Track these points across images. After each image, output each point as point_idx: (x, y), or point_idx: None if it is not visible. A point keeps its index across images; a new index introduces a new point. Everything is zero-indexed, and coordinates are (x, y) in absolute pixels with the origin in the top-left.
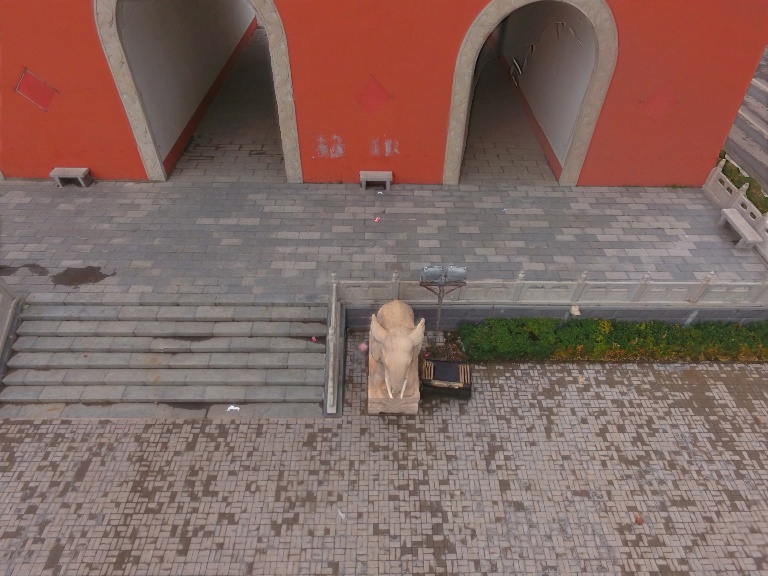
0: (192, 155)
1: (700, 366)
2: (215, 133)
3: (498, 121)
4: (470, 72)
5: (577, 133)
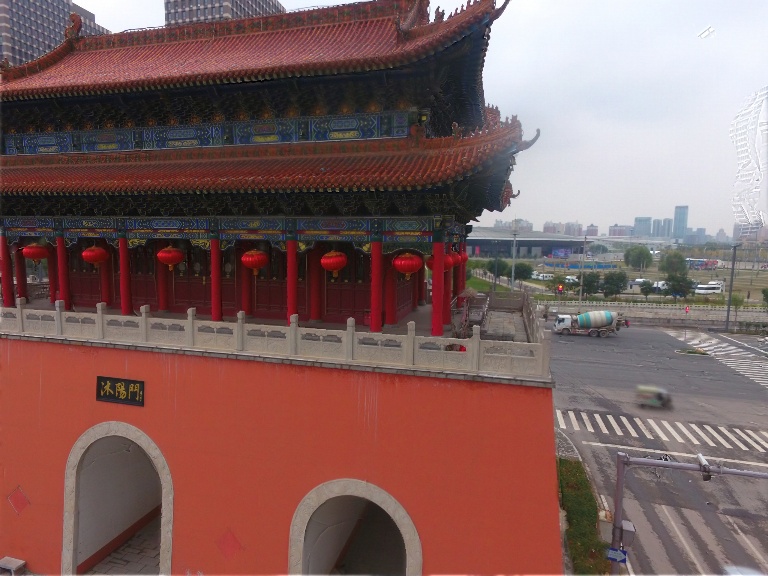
0: (116, 557)
1: None
2: (152, 534)
3: (397, 561)
4: (301, 539)
5: None
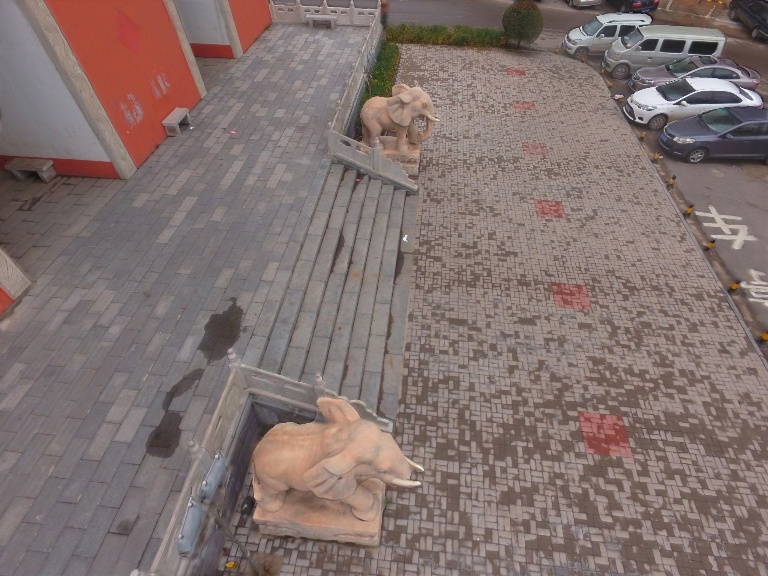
0: None
1: (399, 74)
2: None
3: None
4: None
5: (224, 8)
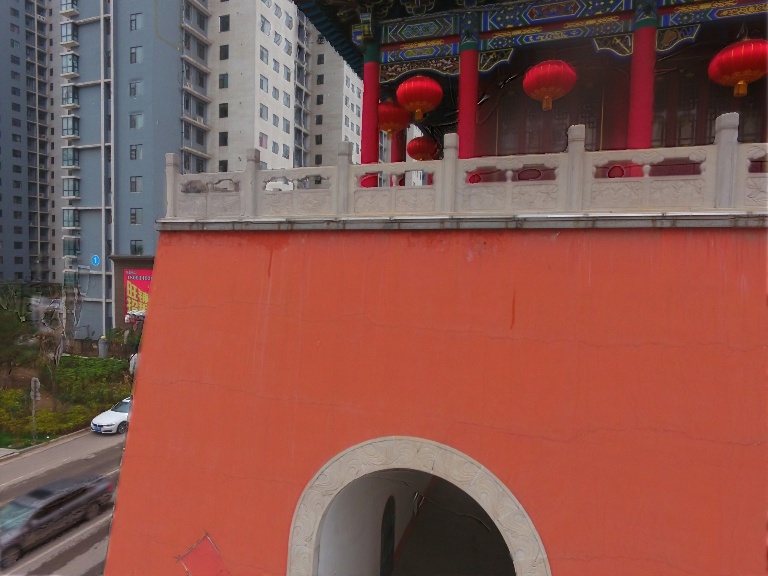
0: None
1: None
2: None
3: None
4: None
5: None
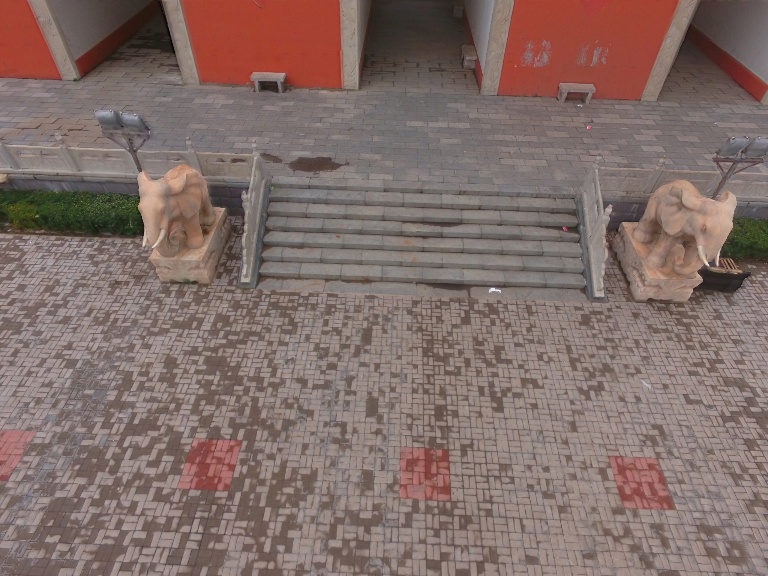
0: (373, 70)
1: None
2: (387, 52)
3: None
4: None
5: None
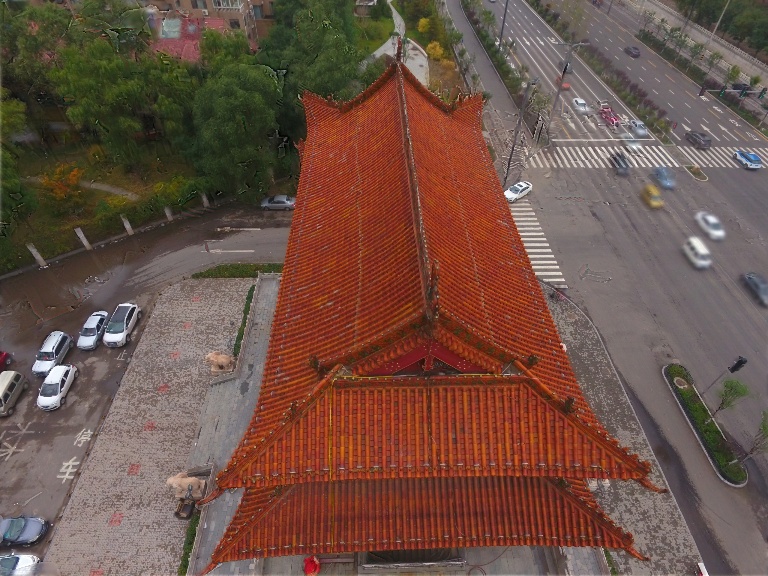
0: None
1: None
2: None
3: None
4: None
5: None
